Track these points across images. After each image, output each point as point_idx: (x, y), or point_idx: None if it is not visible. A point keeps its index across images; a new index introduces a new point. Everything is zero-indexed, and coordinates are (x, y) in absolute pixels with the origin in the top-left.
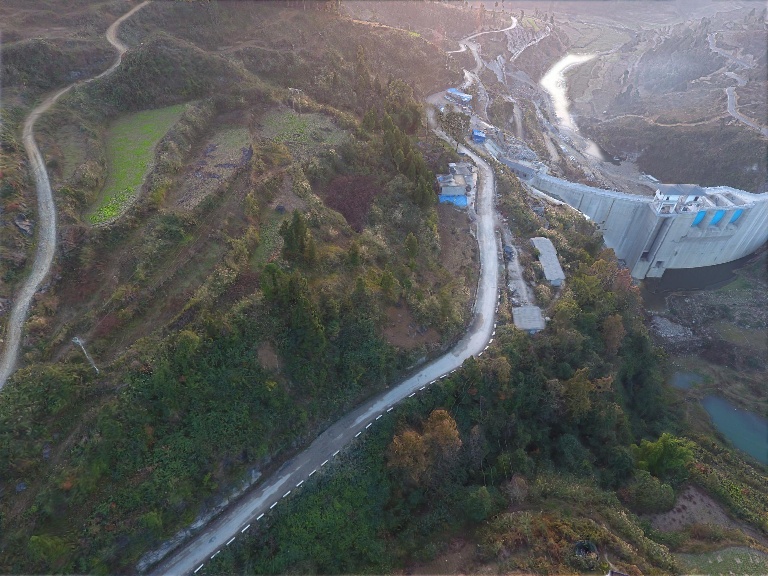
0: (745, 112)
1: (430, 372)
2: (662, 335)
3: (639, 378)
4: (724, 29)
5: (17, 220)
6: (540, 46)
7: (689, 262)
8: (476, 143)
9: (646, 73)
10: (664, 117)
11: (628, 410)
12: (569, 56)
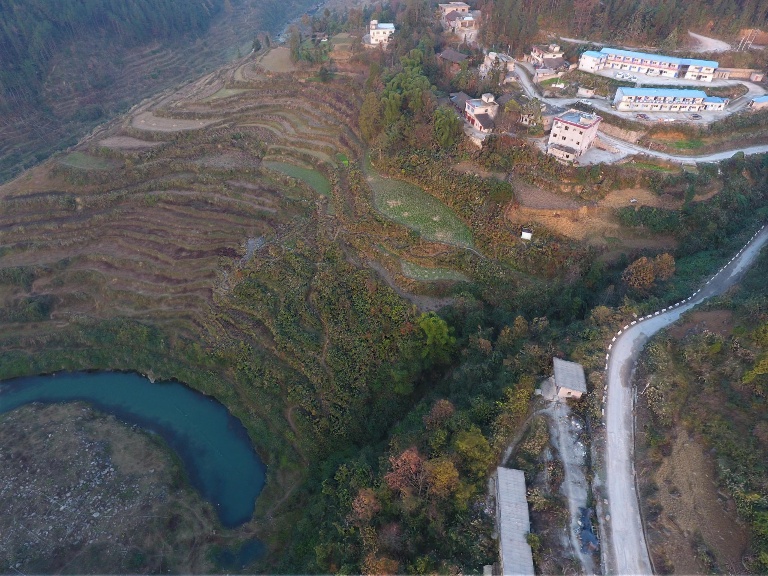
0: None
1: (663, 321)
2: None
3: None
4: None
5: None
6: None
7: None
8: None
9: None
10: None
11: None
12: None
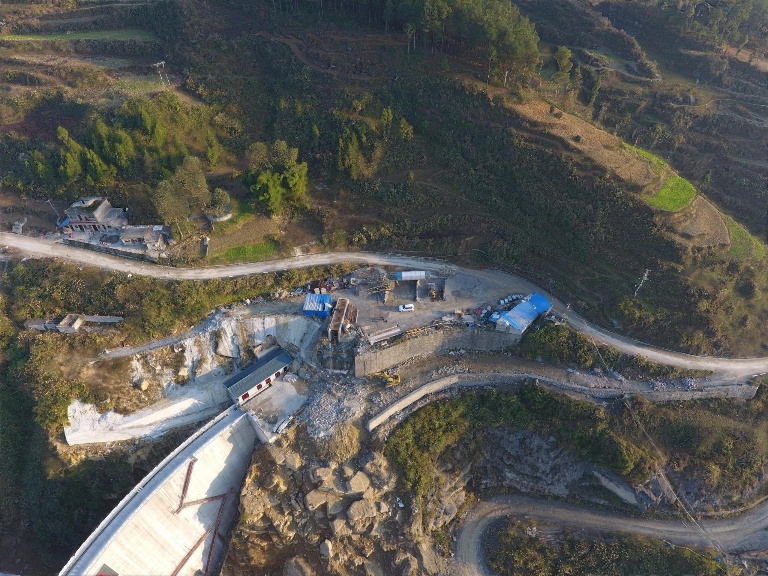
0: None
1: None
2: None
3: None
4: None
5: (0, 20)
6: None
7: None
8: None
9: None
10: None
11: None
12: None
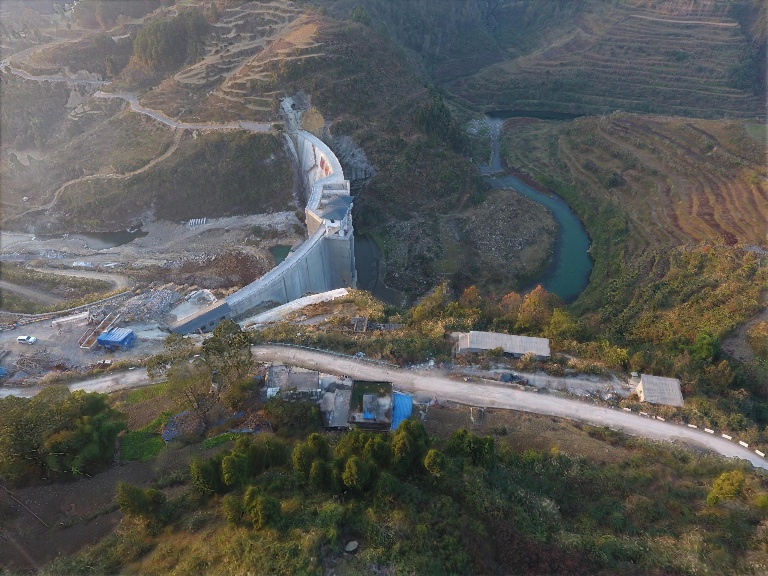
0: (191, 120)
1: None
2: None
3: None
4: None
5: None
6: None
7: None
8: (130, 348)
9: None
10: (126, 164)
11: None
12: None
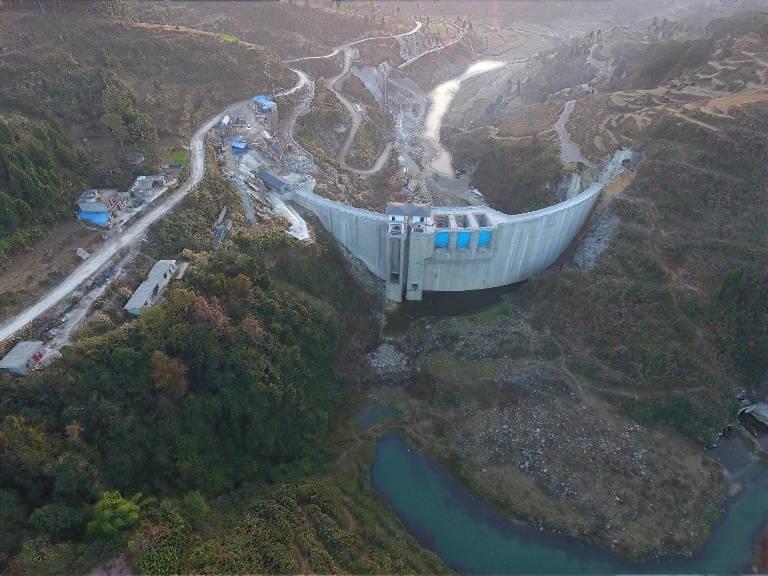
0: (568, 127)
1: None
2: (372, 365)
3: (249, 417)
4: (628, 39)
5: None
6: (444, 53)
7: (455, 285)
8: (235, 154)
9: (527, 83)
10: (502, 130)
11: (239, 451)
12: (478, 64)
